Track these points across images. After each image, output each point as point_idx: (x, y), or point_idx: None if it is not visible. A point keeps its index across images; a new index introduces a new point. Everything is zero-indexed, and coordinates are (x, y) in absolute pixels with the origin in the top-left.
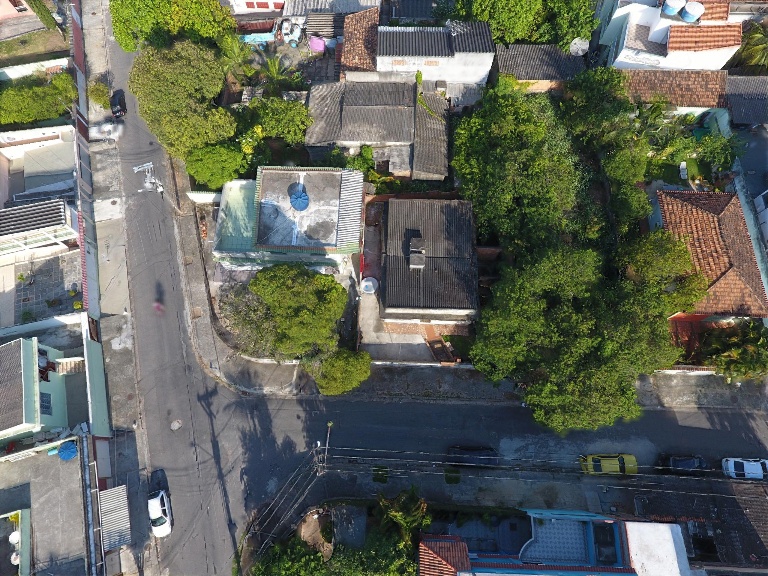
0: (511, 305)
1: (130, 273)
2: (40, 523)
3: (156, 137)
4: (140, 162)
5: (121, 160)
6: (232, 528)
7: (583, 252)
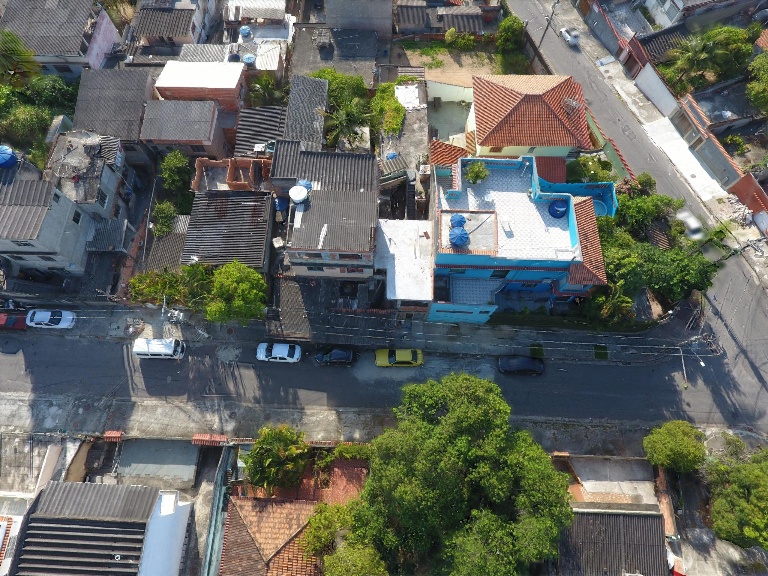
0: (569, 496)
1: None
2: None
3: None
4: None
5: None
6: (717, 312)
7: (479, 573)
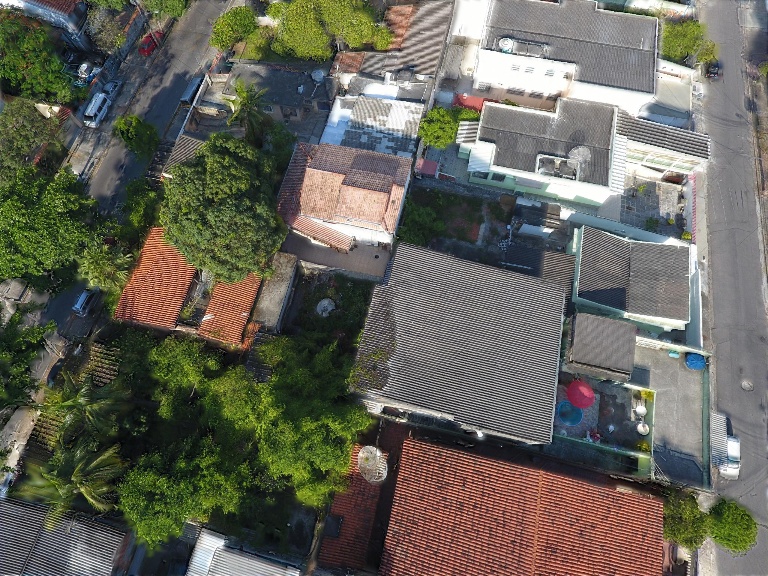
0: None
1: (709, 226)
2: (657, 410)
3: (743, 111)
4: (725, 128)
5: (705, 118)
6: None
7: None
